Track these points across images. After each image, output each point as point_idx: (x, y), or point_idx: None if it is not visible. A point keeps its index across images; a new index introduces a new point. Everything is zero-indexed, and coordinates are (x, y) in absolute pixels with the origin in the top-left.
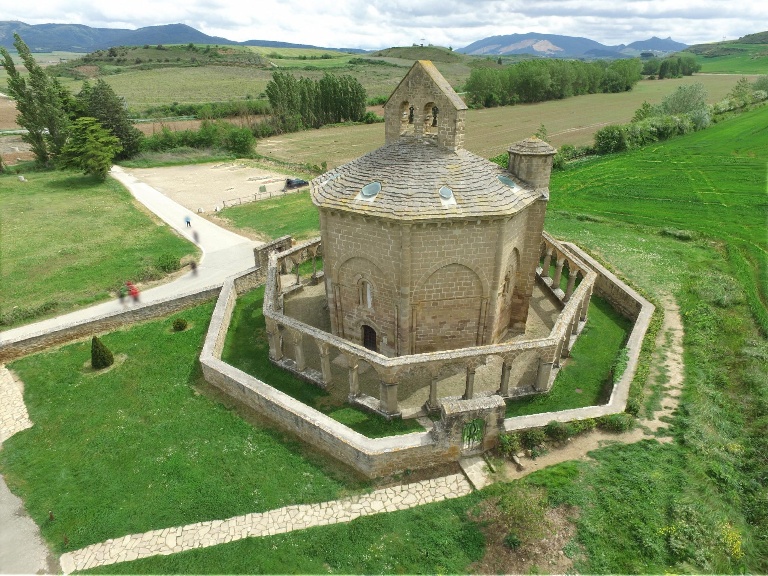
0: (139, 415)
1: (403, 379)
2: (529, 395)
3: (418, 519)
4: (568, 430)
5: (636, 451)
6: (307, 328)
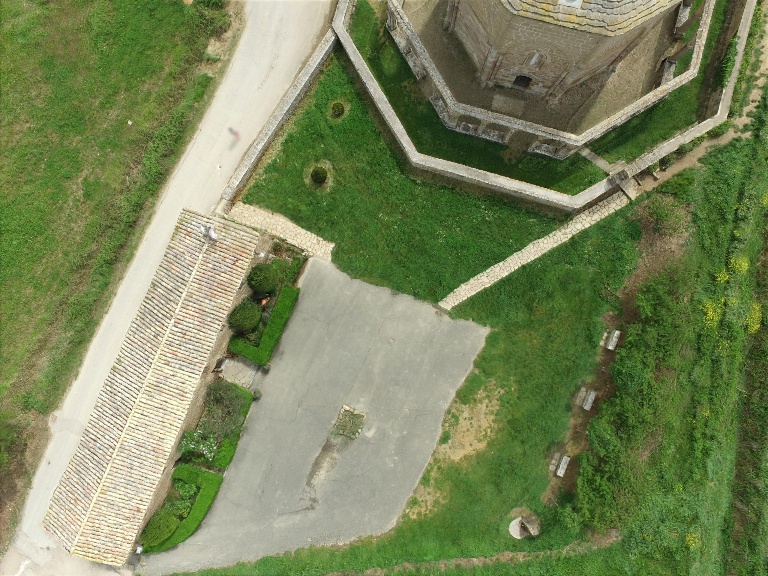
0: (395, 213)
1: (556, 112)
2: (654, 105)
3: (604, 228)
4: (691, 150)
5: (729, 152)
6: (502, 120)
